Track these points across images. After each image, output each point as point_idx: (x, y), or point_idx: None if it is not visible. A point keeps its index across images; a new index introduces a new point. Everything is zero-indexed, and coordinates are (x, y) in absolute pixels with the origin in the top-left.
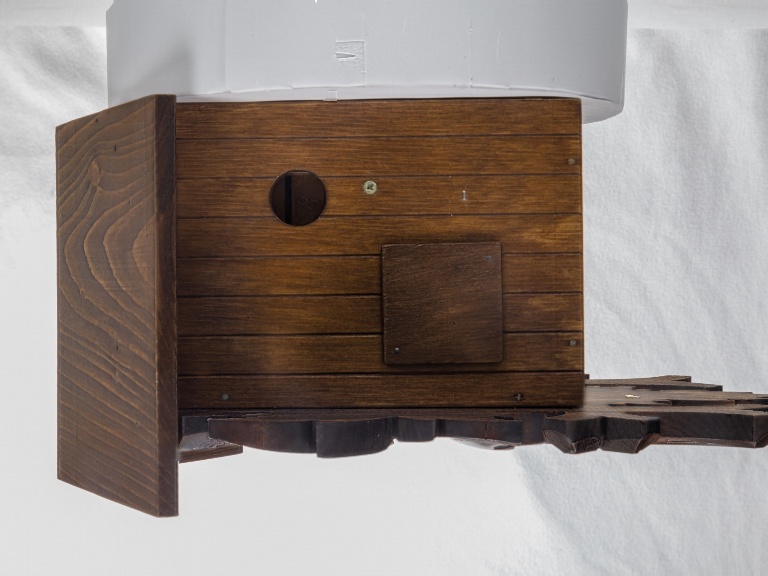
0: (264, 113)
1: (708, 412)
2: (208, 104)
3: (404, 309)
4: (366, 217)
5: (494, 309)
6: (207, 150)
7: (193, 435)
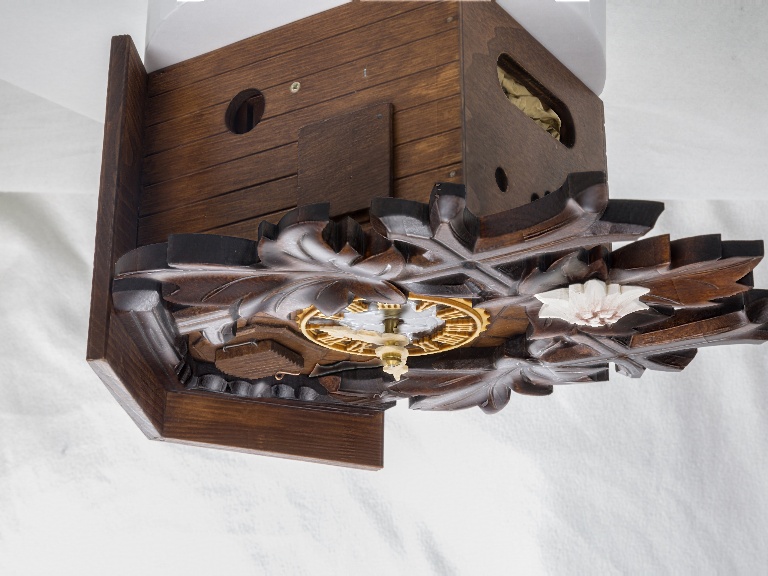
0: (225, 54)
1: (549, 194)
2: (189, 60)
3: (312, 176)
4: (292, 112)
5: (383, 158)
6: (186, 94)
7: (122, 293)
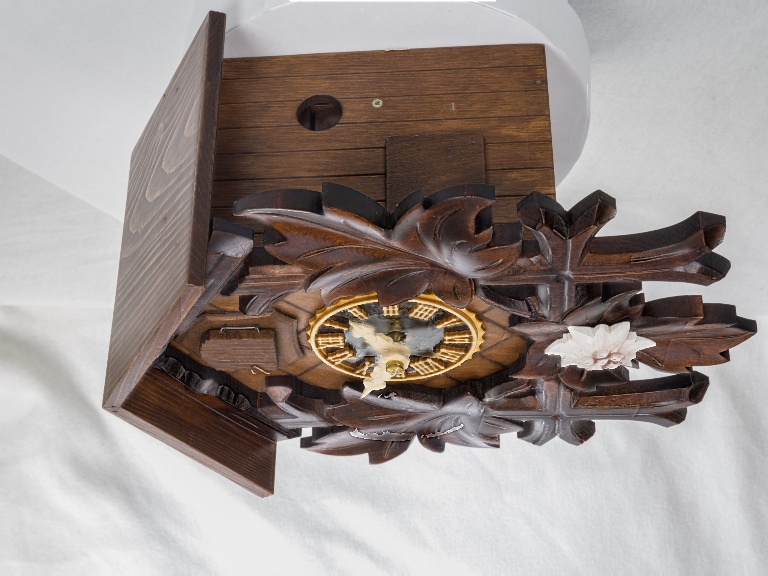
0: (295, 61)
1: None
2: (252, 58)
3: (404, 178)
4: (374, 123)
5: (479, 176)
6: (249, 85)
7: (222, 233)
